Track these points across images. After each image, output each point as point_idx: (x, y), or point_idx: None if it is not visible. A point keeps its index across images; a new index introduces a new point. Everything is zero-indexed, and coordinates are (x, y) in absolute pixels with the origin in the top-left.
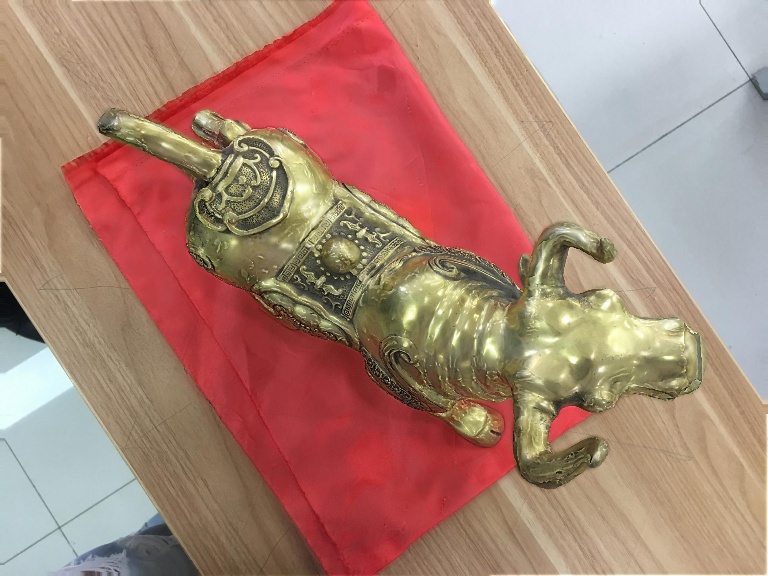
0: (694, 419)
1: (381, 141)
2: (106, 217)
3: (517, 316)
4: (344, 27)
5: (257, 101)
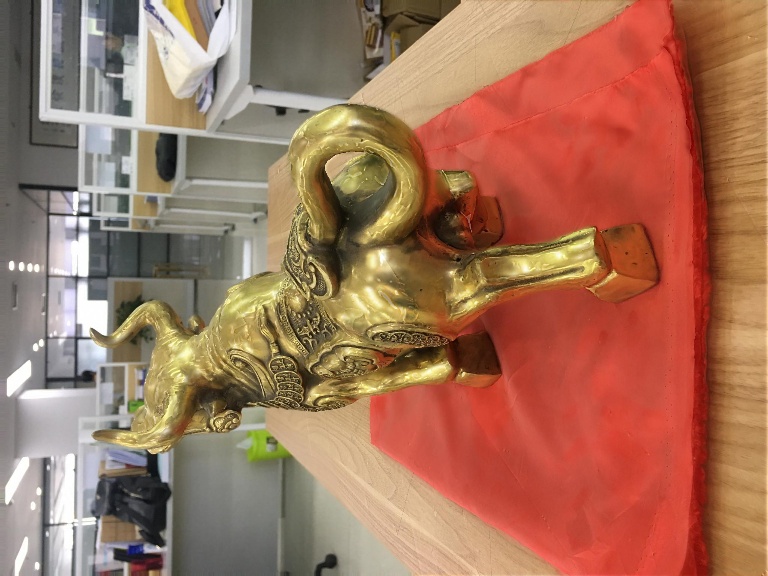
0: (358, 464)
1: (549, 456)
2: (628, 36)
3: (185, 371)
4: (648, 563)
5: (658, 353)
